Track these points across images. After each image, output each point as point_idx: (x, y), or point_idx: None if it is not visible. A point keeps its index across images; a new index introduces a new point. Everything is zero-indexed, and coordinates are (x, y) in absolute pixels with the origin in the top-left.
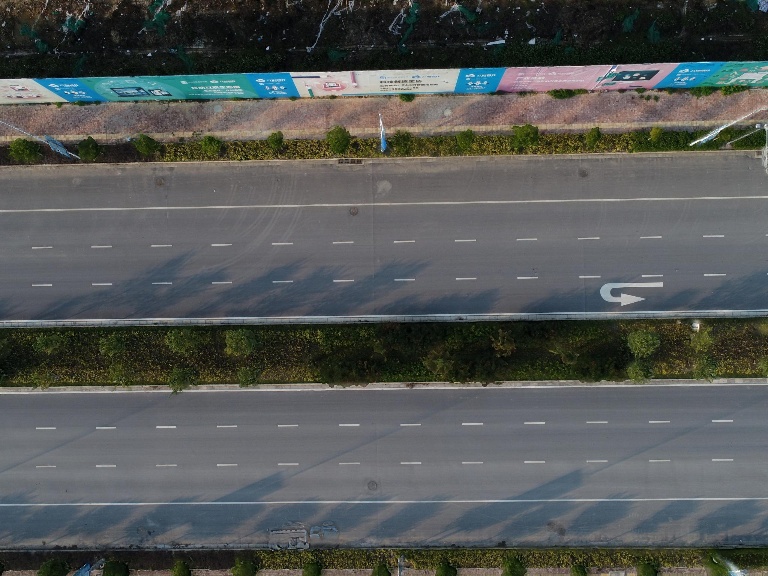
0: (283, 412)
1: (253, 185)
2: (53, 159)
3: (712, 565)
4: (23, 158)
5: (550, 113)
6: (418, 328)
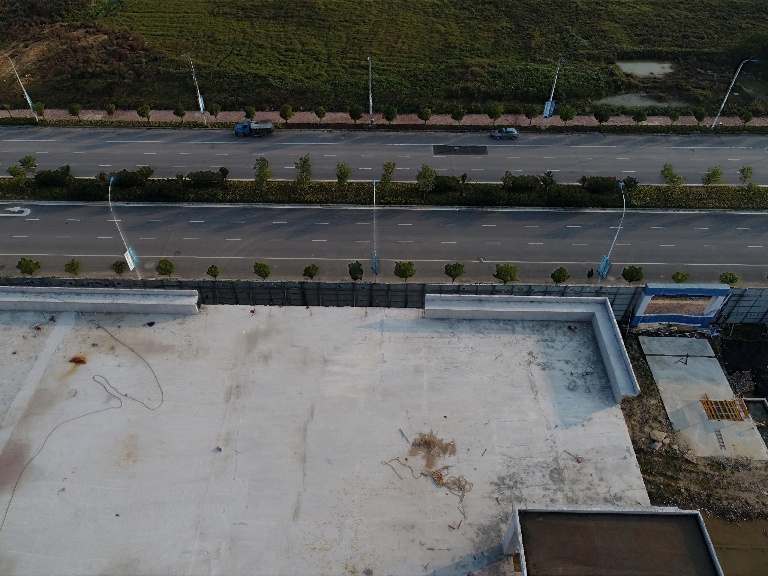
0: None
1: (246, 269)
2: None
3: (39, 109)
4: None
5: None
6: (153, 191)
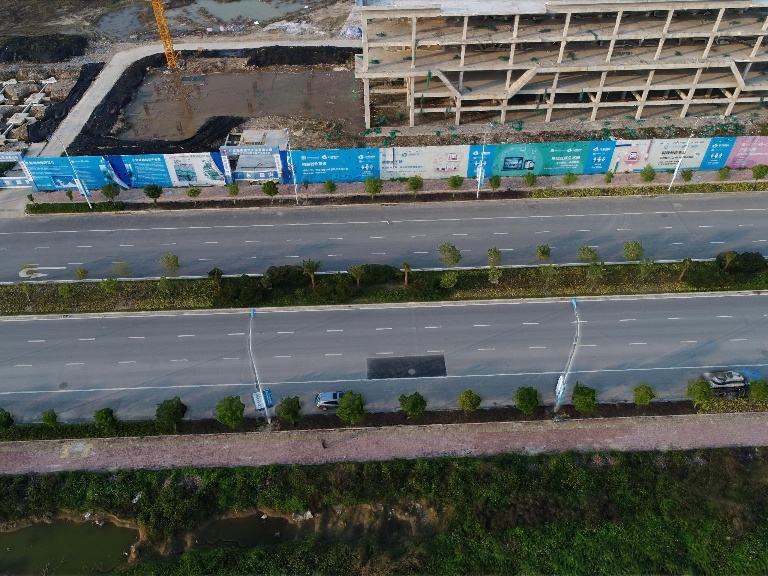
0: (668, 310)
1: (593, 207)
2: (460, 198)
3: None
4: (442, 197)
5: None
6: (748, 253)
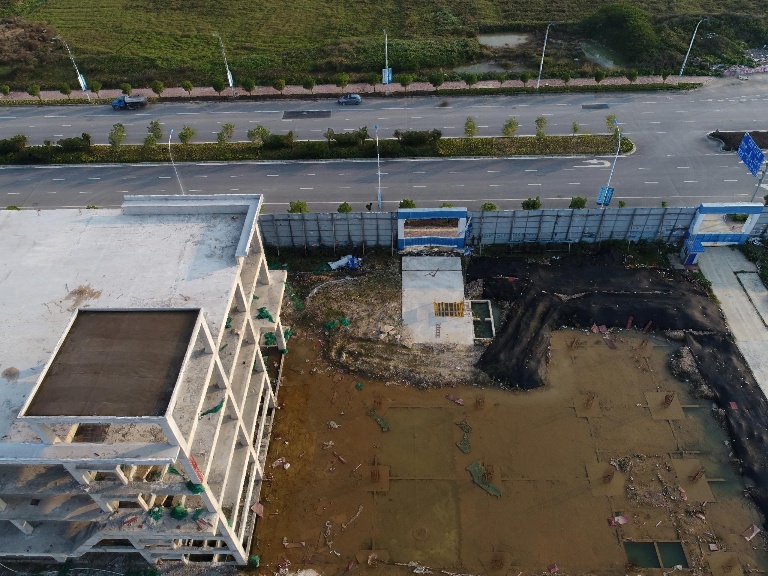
0: None
1: None
2: None
3: None
4: None
5: None
6: (24, 155)
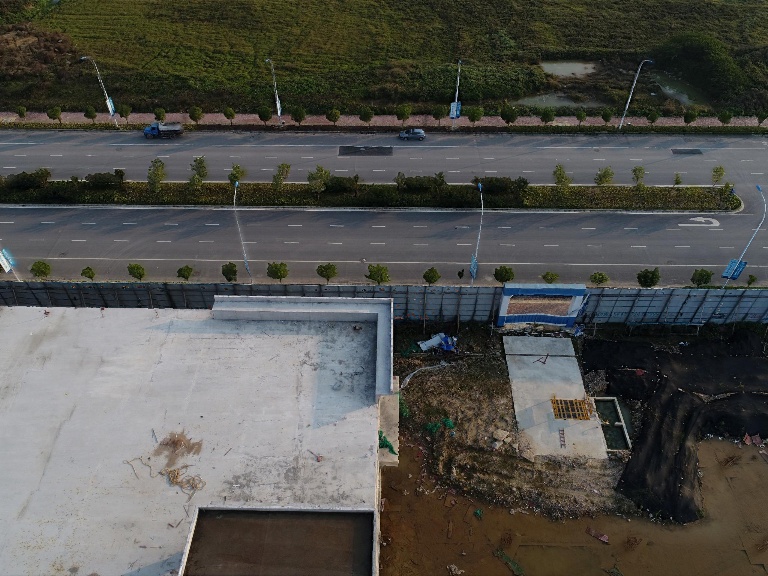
0: None
1: None
2: None
3: None
4: None
5: None
6: (48, 193)
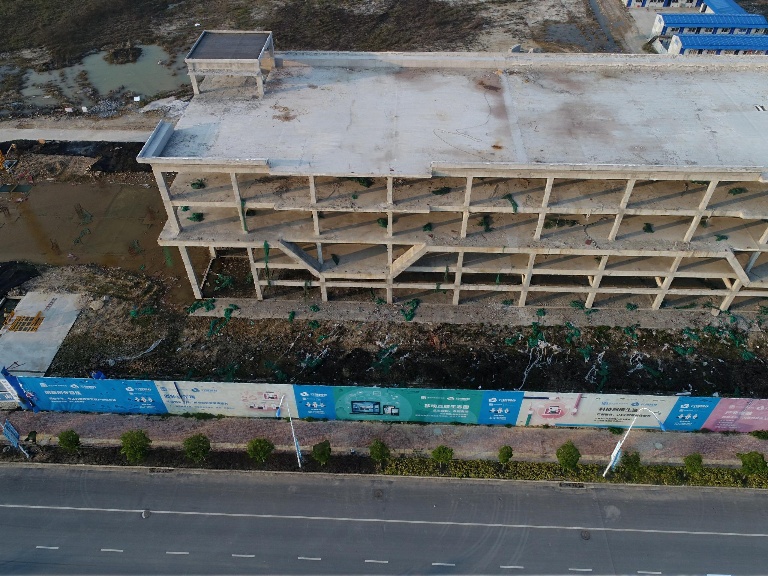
0: None
1: (474, 502)
2: (274, 466)
3: None
4: (245, 463)
5: (759, 451)
6: None
